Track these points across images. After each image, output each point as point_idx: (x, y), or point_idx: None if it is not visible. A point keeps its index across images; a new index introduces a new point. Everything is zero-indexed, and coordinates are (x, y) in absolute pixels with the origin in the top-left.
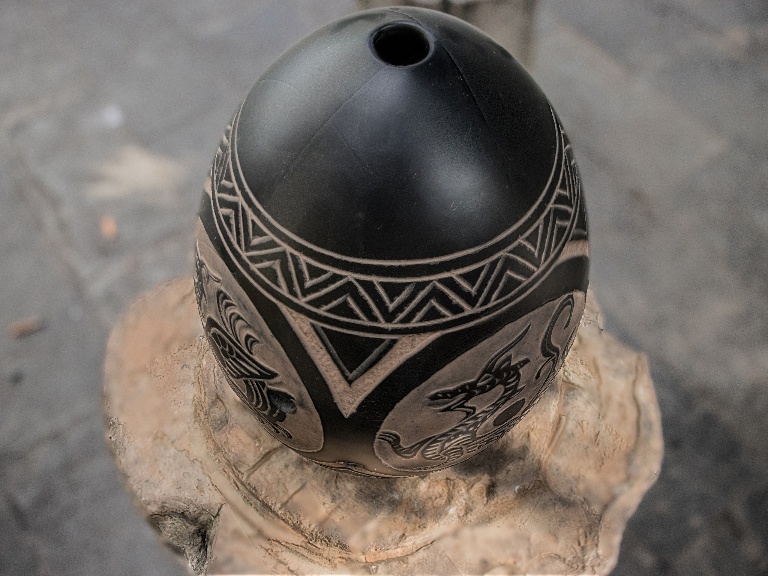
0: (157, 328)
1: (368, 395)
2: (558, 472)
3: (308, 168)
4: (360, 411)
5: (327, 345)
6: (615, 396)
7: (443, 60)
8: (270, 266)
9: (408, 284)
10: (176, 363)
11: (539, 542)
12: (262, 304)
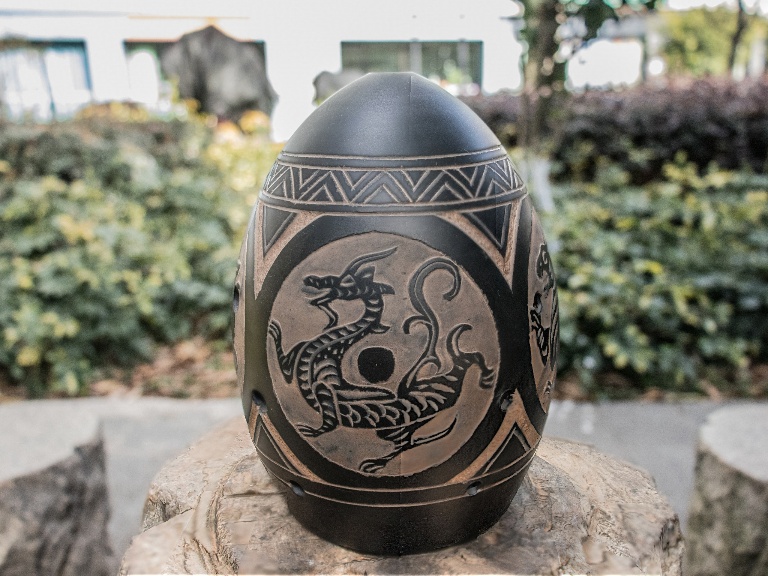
0: None
1: (270, 269)
2: None
3: None
4: (263, 289)
5: None
6: None
7: (404, 75)
8: None
9: (315, 170)
10: None
11: None
12: None
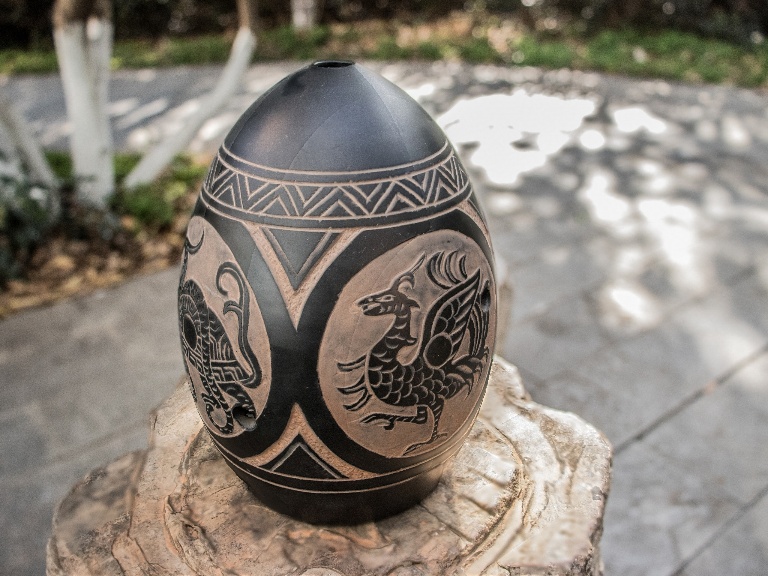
0: None
1: None
2: None
3: (402, 119)
4: None
5: None
6: None
7: None
8: (440, 188)
9: None
10: None
11: None
12: (453, 221)
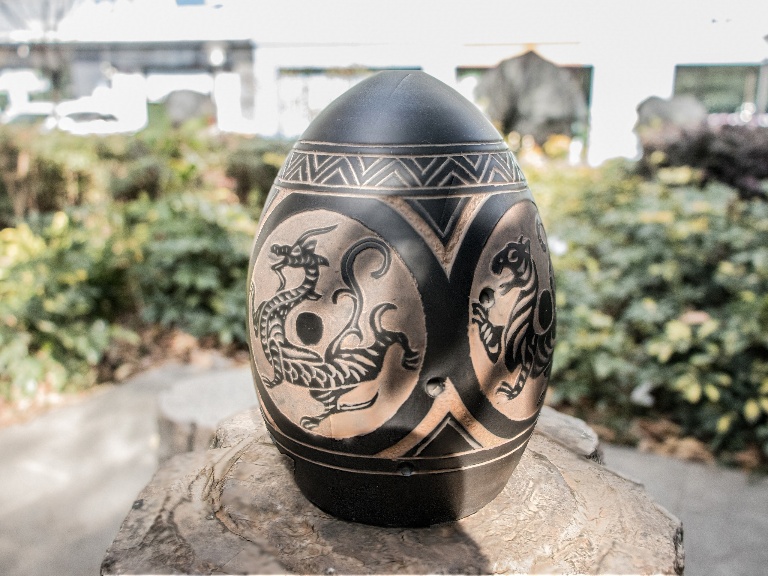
0: None
1: None
2: None
3: None
4: None
5: None
6: None
7: None
8: None
9: None
10: None
11: None
12: None
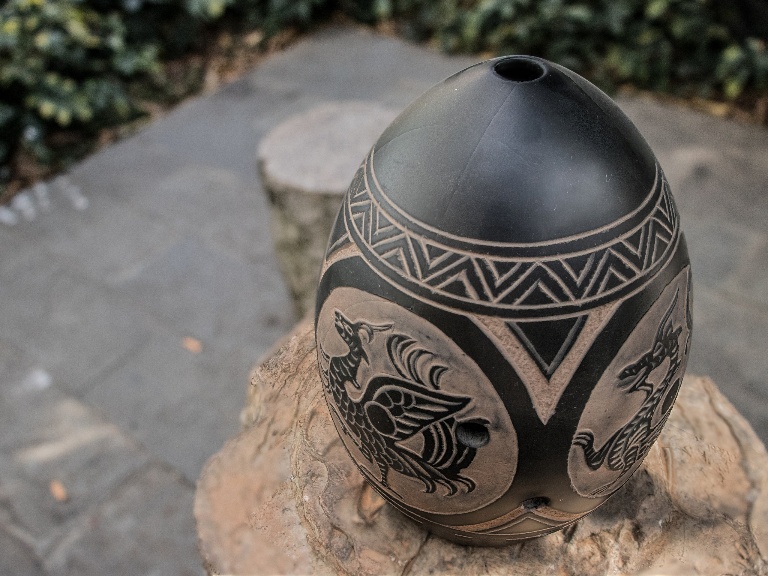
0: (242, 483)
1: (566, 387)
2: (688, 498)
3: (477, 177)
4: (559, 411)
5: (524, 341)
6: (701, 418)
7: (557, 73)
8: (455, 280)
9: (589, 255)
10: (275, 510)
11: (705, 568)
12: (450, 324)
